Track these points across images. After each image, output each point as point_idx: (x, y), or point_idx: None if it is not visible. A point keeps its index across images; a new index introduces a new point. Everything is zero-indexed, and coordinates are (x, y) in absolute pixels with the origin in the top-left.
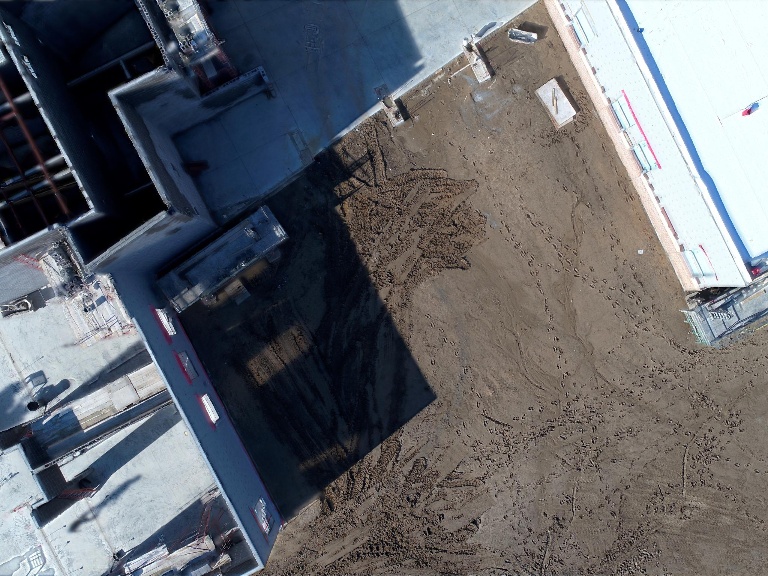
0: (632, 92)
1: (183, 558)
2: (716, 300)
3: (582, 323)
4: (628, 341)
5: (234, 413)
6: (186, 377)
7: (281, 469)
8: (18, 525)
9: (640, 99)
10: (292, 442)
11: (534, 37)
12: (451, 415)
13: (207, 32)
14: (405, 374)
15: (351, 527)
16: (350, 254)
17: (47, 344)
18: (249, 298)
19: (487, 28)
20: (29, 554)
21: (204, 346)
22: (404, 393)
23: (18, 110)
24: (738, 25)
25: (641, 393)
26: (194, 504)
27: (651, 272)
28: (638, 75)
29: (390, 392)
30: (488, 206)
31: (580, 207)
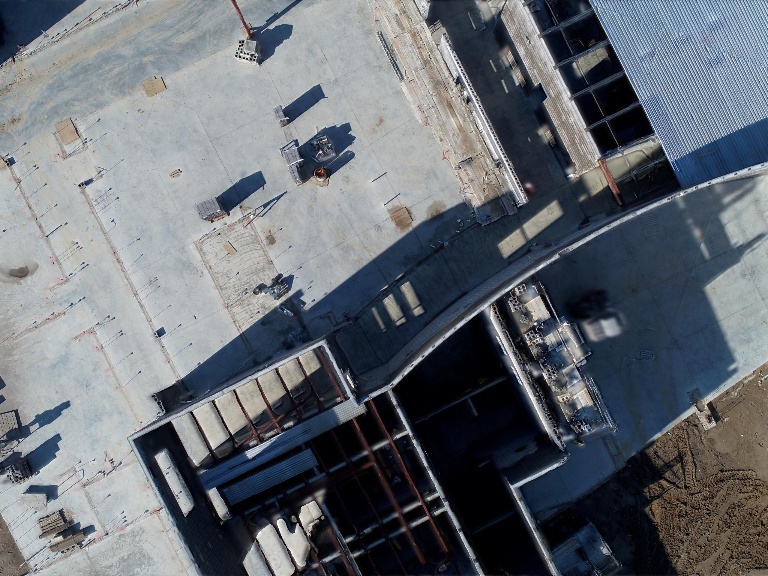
0: None
1: None
2: None
3: None
4: None
5: None
6: None
7: None
8: None
9: None
10: None
11: None
12: None
13: (610, 423)
14: None
15: None
16: (659, 556)
17: None
18: None
19: None
20: None
21: None
22: None
23: None
24: None
25: None
26: None
27: None
28: None
29: None
30: None
31: None
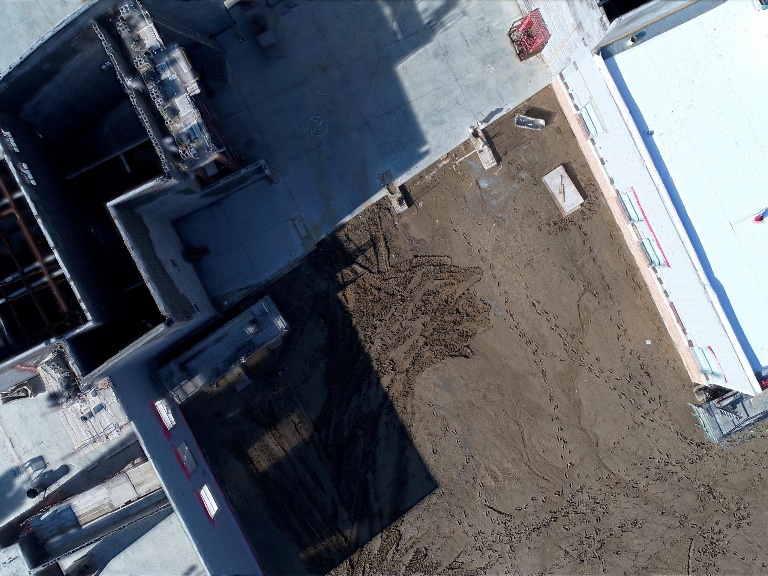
0: (641, 191)
1: None
2: (725, 396)
3: (587, 413)
4: (634, 432)
5: (233, 500)
6: (185, 473)
7: (280, 557)
8: None
9: (649, 200)
10: (291, 530)
11: (542, 123)
12: (452, 504)
13: (207, 143)
14: (406, 463)
15: None
16: (352, 341)
17: (47, 429)
18: (249, 385)
19: (494, 114)
20: None
21: (204, 432)
22: (405, 482)
23: (18, 207)
24: (752, 127)
25: (646, 484)
26: None
27: (658, 362)
28: (648, 178)
29: (391, 481)
30: (493, 294)
31: (587, 296)
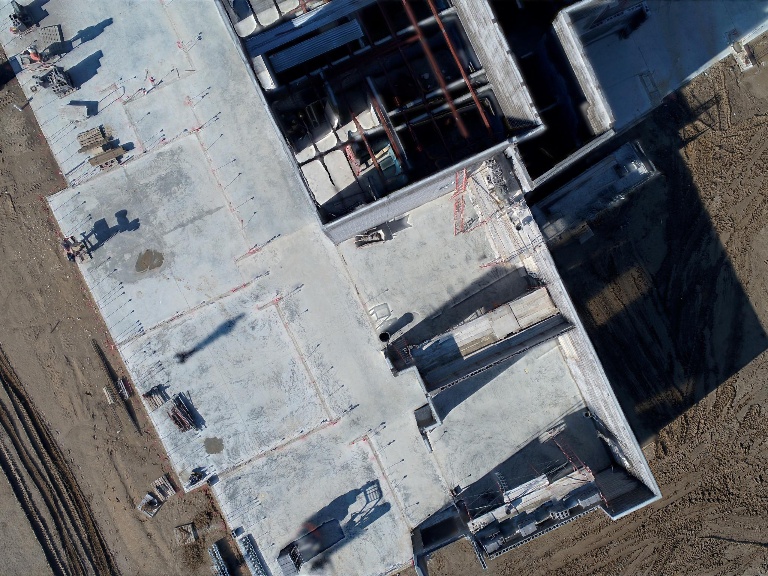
0: None
1: (563, 489)
2: None
3: None
4: None
5: None
6: None
7: None
8: (356, 458)
9: None
10: (628, 384)
11: None
12: None
13: None
14: (742, 319)
15: (684, 472)
16: (692, 197)
17: (392, 277)
18: (591, 238)
19: None
20: (366, 487)
21: None
22: (741, 338)
23: None
24: None
25: None
26: (532, 442)
27: None
28: None
29: (727, 337)
30: None
31: None
